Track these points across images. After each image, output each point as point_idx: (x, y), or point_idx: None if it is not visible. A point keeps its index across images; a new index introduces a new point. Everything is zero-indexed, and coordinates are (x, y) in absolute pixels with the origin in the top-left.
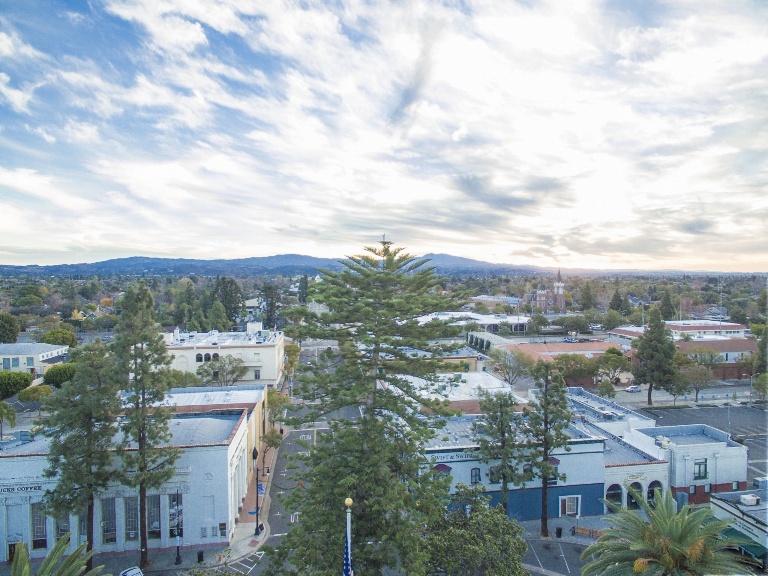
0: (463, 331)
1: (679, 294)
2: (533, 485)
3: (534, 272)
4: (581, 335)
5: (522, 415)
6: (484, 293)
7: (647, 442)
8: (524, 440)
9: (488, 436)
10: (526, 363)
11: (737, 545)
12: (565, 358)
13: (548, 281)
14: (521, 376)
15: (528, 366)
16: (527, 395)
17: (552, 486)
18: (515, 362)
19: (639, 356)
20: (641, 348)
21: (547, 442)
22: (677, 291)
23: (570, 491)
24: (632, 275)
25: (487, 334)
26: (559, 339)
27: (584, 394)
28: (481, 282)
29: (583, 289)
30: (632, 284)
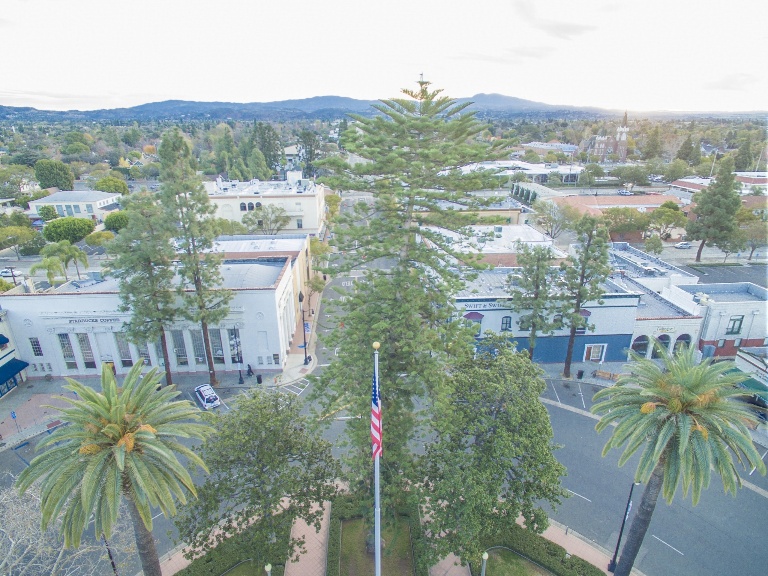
0: (509, 181)
1: (762, 141)
2: (561, 333)
3: (597, 114)
4: (638, 187)
5: (559, 269)
6: (536, 139)
7: (685, 298)
8: (558, 293)
9: (522, 288)
10: (572, 217)
11: (753, 393)
12: (615, 212)
13: (611, 125)
14: (565, 230)
15: (573, 220)
16: (567, 249)
17: (580, 335)
18: (560, 215)
19: (697, 211)
20: (701, 203)
21: (581, 295)
22: (761, 137)
23: (597, 340)
24: (712, 118)
25: (534, 185)
26: (612, 191)
27: (629, 249)
28: (535, 126)
29: (650, 135)
30: (709, 129)
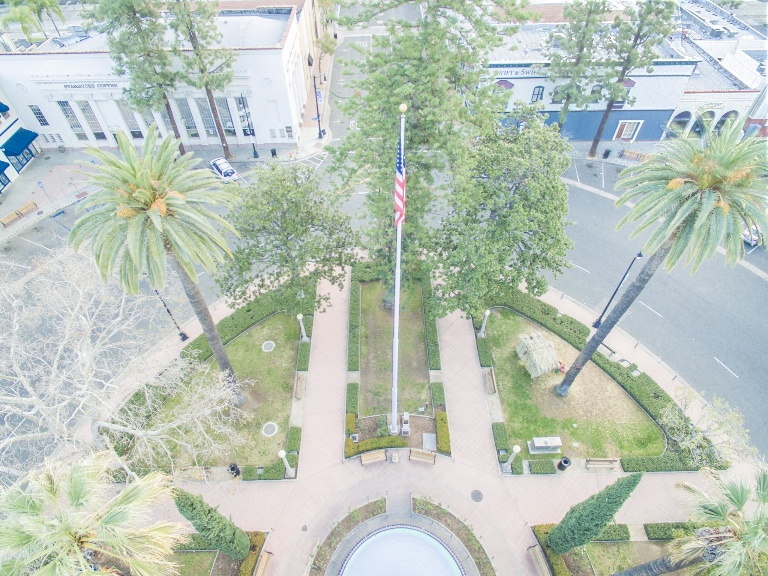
0: None
1: None
2: (596, 107)
3: None
4: None
5: (611, 26)
6: None
7: (748, 67)
8: (603, 57)
9: (563, 51)
10: None
11: None
12: None
13: None
14: None
15: None
16: None
17: (616, 110)
18: None
19: None
20: None
21: (629, 61)
22: None
23: (634, 116)
24: None
25: None
26: None
27: (700, 1)
28: None
29: None
30: None
